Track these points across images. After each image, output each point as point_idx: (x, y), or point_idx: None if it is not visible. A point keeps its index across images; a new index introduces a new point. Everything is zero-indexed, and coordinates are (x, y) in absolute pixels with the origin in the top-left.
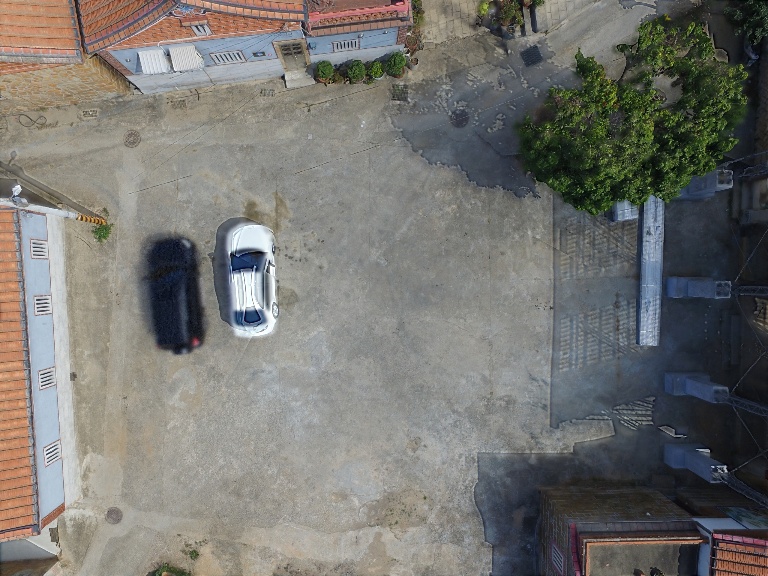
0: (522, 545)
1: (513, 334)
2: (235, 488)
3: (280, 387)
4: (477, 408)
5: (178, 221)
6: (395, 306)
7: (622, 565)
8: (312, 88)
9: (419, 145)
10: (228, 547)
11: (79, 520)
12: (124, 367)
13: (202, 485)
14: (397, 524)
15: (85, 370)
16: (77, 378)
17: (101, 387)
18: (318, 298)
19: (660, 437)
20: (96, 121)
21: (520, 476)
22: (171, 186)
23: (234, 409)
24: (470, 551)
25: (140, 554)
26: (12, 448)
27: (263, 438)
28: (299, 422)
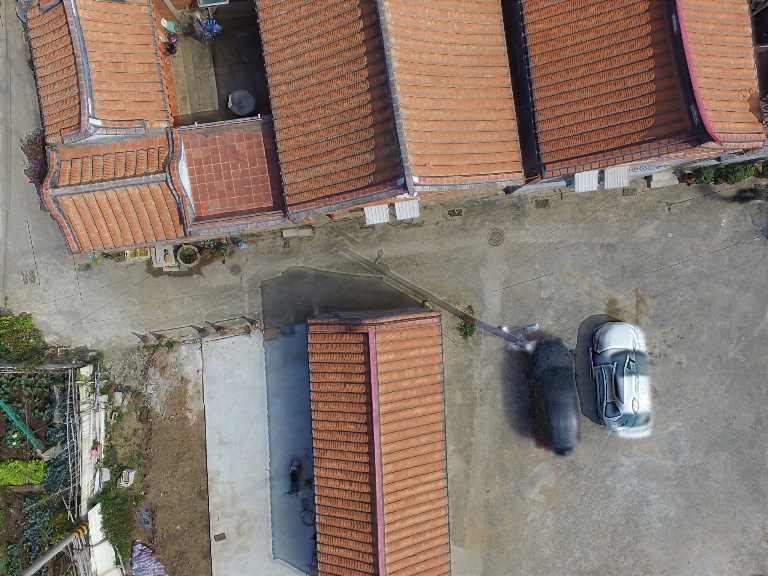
0: None
1: None
2: None
3: (638, 481)
4: None
5: (541, 318)
6: (753, 401)
7: None
8: (674, 188)
9: None
10: None
11: None
12: (487, 461)
13: None
14: None
15: (449, 464)
16: None
17: (464, 481)
18: (677, 393)
19: None
20: (461, 220)
21: None
22: (534, 284)
23: (592, 502)
24: None
25: None
26: (436, 556)
27: (620, 530)
28: (656, 515)
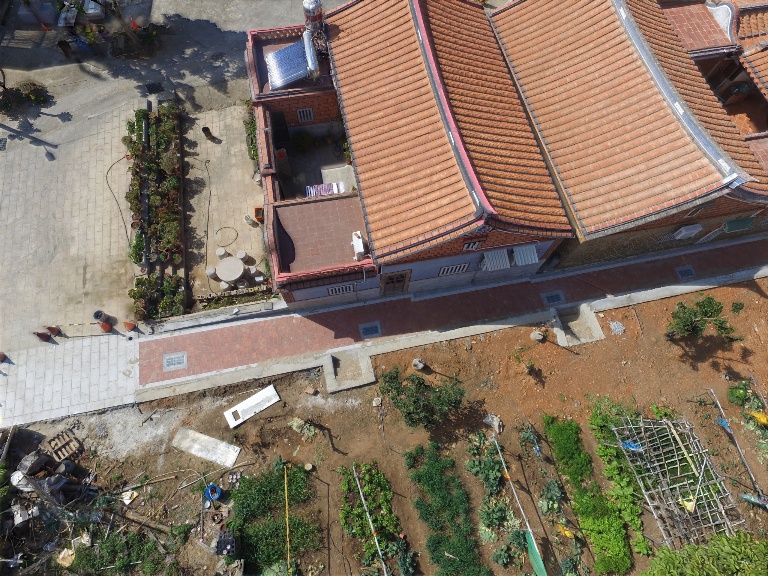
0: None
1: None
2: None
3: None
4: None
5: None
6: None
7: None
8: None
9: None
10: None
11: None
12: None
13: None
14: None
15: None
16: None
17: None
18: None
19: None
20: None
21: None
22: None
23: None
24: None
25: None
26: None
27: None
28: None
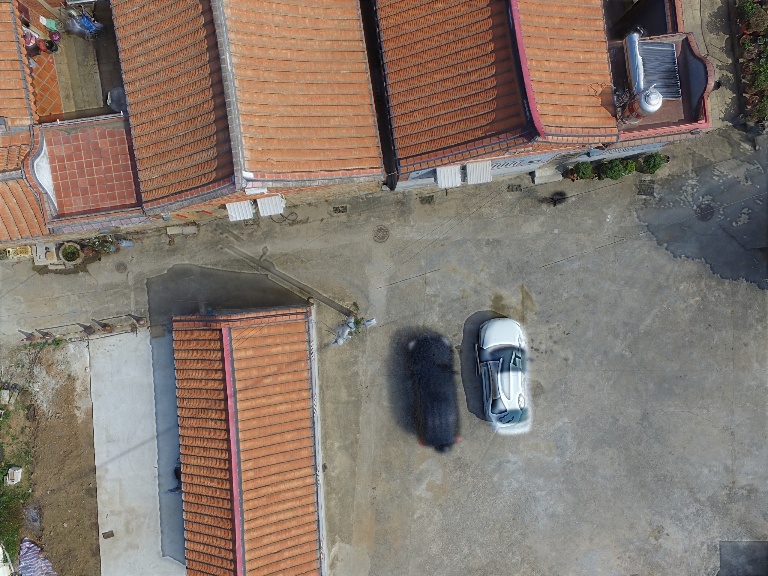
0: None
1: (755, 424)
2: None
3: (525, 477)
4: (719, 497)
5: (426, 314)
6: (639, 397)
7: None
8: (558, 183)
9: (664, 239)
10: None
11: None
12: (373, 458)
13: (447, 573)
14: None
15: (335, 461)
16: (327, 469)
17: (351, 478)
18: (564, 390)
19: None
20: (346, 217)
21: (762, 564)
22: (419, 280)
23: (480, 499)
24: None
25: None
26: (303, 552)
27: (508, 527)
28: (544, 511)
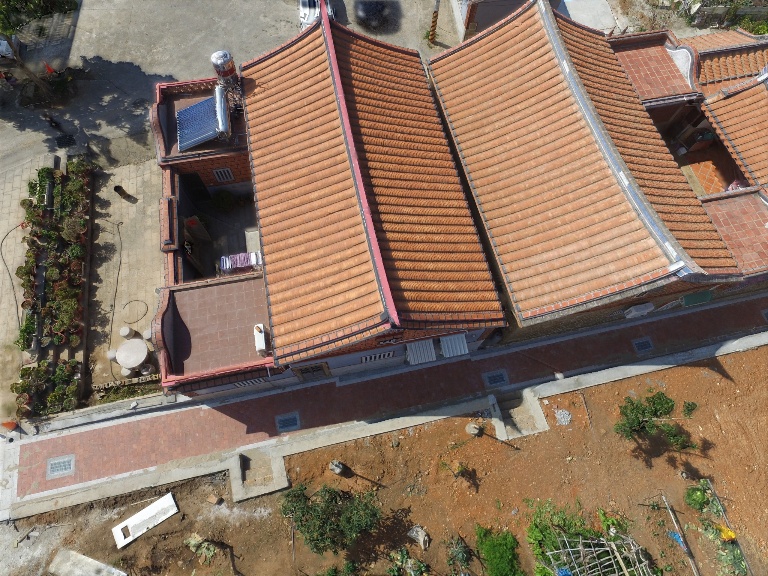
0: None
1: None
2: None
3: None
4: None
5: None
6: None
7: None
8: None
9: None
10: None
11: None
12: None
13: None
14: None
15: None
16: None
17: None
18: None
19: None
20: None
21: None
22: None
23: None
24: None
25: None
26: None
27: None
28: None
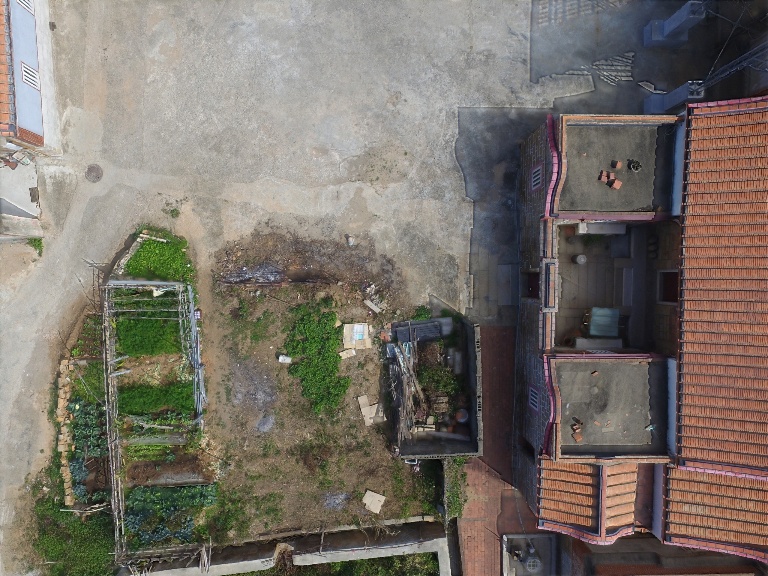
0: (503, 201)
1: None
2: (216, 144)
3: (260, 40)
4: (457, 62)
5: None
6: None
7: (599, 155)
8: None
9: None
10: (209, 204)
11: (59, 178)
12: (104, 18)
13: (183, 141)
14: (378, 180)
15: (64, 21)
16: (56, 29)
17: (81, 38)
18: None
19: (639, 93)
20: None
21: (500, 131)
22: None
23: (214, 63)
24: (451, 206)
25: (121, 215)
26: None
27: (243, 93)
28: (279, 76)
